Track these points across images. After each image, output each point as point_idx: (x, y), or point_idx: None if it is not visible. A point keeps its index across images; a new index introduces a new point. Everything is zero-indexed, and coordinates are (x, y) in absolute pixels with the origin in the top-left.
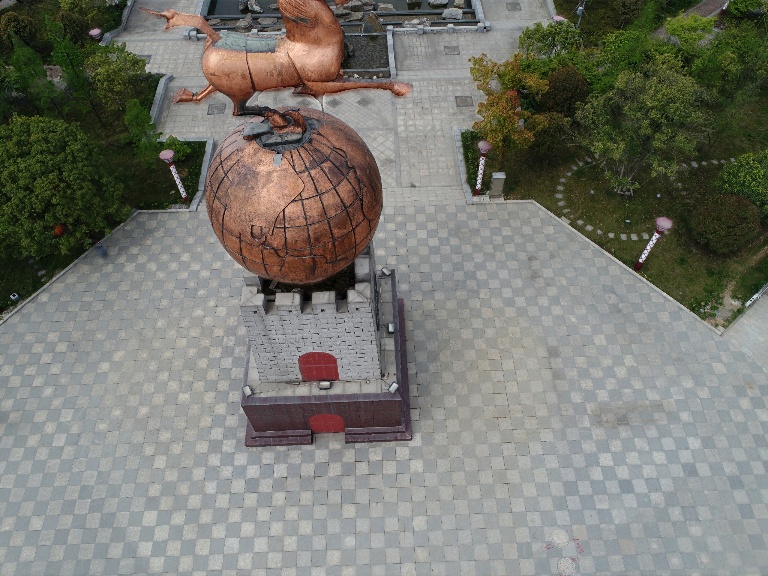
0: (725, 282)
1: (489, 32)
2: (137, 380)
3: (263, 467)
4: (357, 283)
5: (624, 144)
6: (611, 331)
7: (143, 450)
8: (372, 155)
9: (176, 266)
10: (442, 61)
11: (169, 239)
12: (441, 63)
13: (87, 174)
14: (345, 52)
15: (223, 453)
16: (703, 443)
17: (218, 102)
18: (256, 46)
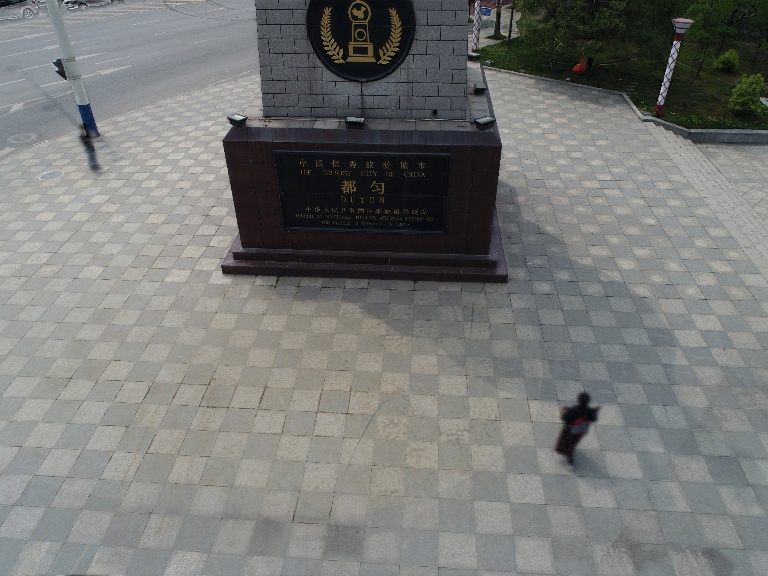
0: None
1: None
2: None
3: None
4: None
5: None
6: None
7: None
8: None
9: (544, 116)
10: None
11: (586, 111)
12: None
13: None
14: None
15: None
16: None
17: None
18: None
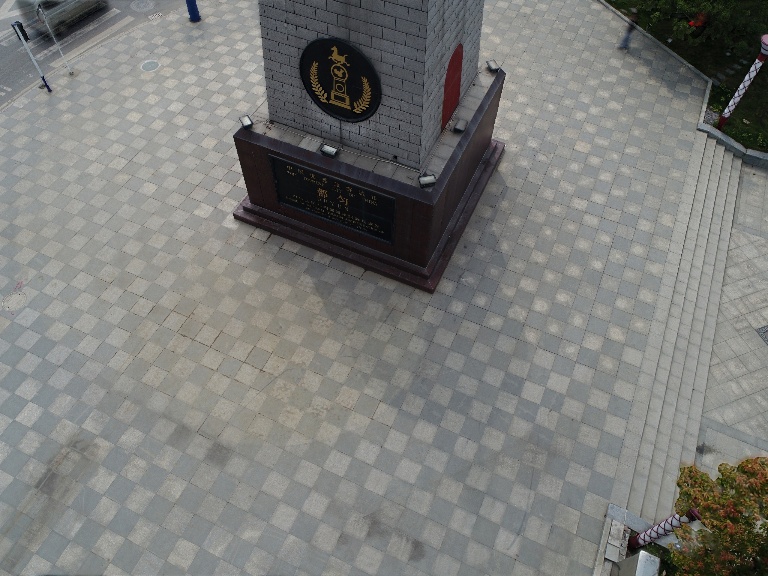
0: None
1: None
2: None
3: None
4: None
5: None
6: None
7: None
8: None
9: (603, 95)
10: None
11: (652, 98)
12: None
13: None
14: None
15: None
16: None
17: None
18: None
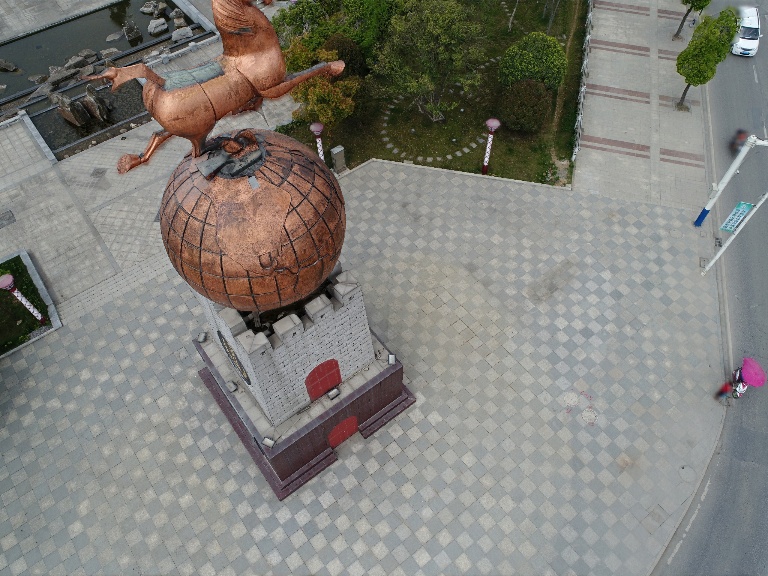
0: (548, 151)
1: None
2: (123, 517)
3: (309, 507)
4: (337, 277)
5: (427, 76)
6: (500, 228)
7: (181, 574)
8: None
9: (81, 389)
10: None
11: (53, 368)
12: None
13: None
14: (104, 108)
15: (263, 521)
16: (612, 271)
17: None
18: (204, 75)
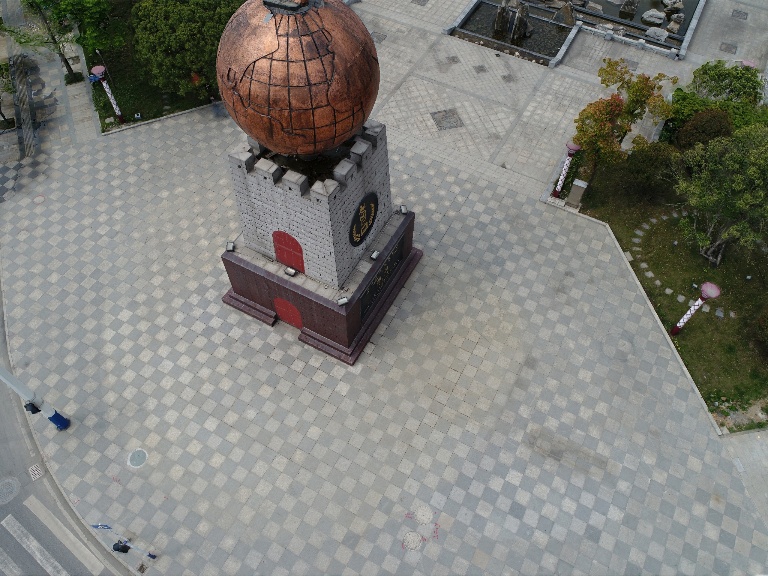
0: (766, 392)
1: (680, 61)
2: (180, 214)
3: (225, 323)
4: None
5: (717, 197)
6: (602, 373)
7: (151, 265)
8: (371, 58)
9: None
10: None
11: None
12: None
13: None
14: (522, 30)
15: (204, 297)
16: (625, 519)
17: (382, 32)
18: None
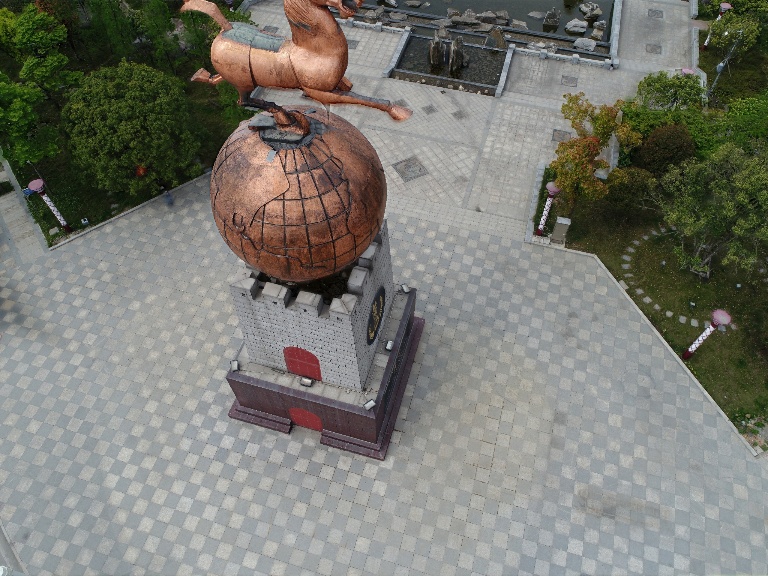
0: None
1: (616, 70)
2: (158, 326)
3: (238, 441)
4: (345, 293)
5: (705, 221)
6: (631, 415)
7: (141, 391)
8: (379, 172)
9: None
10: (555, 90)
11: None
12: (553, 92)
13: (169, 127)
14: (459, 61)
15: (207, 416)
16: (691, 566)
17: None
18: (262, 43)
